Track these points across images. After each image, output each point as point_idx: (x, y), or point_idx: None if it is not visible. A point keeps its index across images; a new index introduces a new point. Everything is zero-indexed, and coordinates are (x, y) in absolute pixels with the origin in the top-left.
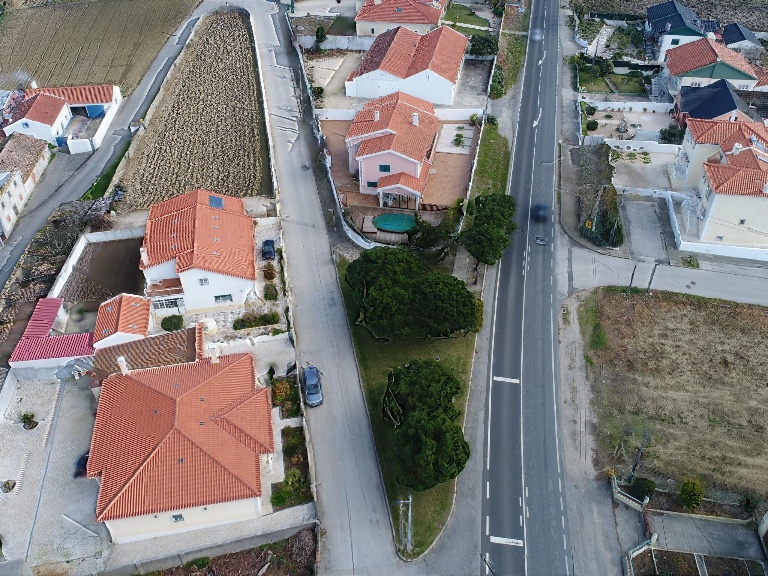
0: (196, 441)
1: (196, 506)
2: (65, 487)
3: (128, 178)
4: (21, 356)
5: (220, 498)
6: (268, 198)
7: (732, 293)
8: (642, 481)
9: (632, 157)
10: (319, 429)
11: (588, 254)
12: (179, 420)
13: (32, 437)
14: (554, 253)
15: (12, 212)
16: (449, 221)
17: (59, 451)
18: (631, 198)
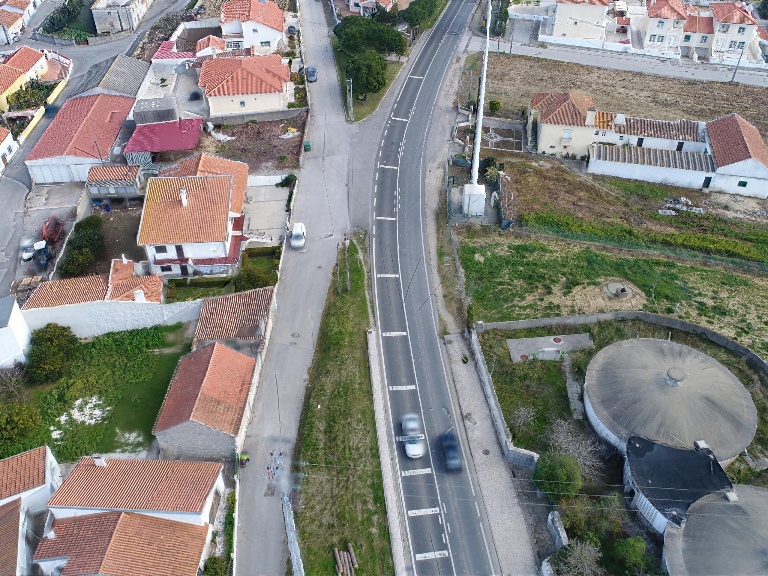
0: (252, 73)
1: (252, 94)
2: (185, 104)
3: (206, 4)
4: (158, 57)
5: (263, 92)
6: (293, 12)
7: (561, 58)
8: (472, 101)
9: (528, 3)
10: (314, 89)
11: (481, 39)
12: (244, 66)
13: (166, 90)
14: (461, 37)
15: (137, 17)
16: (396, 7)
17: (180, 94)
18: (519, 20)
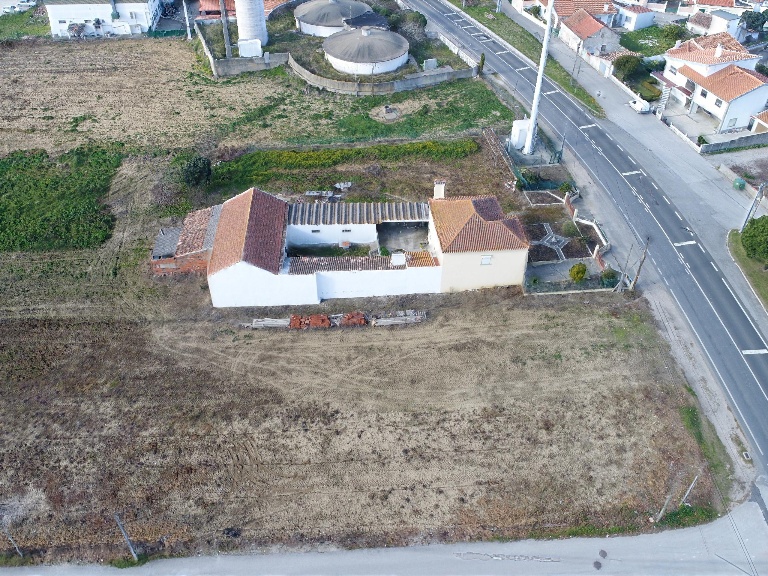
0: None
1: None
2: None
3: None
4: None
5: None
6: None
7: None
8: None
9: None
10: None
11: None
12: None
13: None
14: None
15: None
16: None
17: None
18: None
